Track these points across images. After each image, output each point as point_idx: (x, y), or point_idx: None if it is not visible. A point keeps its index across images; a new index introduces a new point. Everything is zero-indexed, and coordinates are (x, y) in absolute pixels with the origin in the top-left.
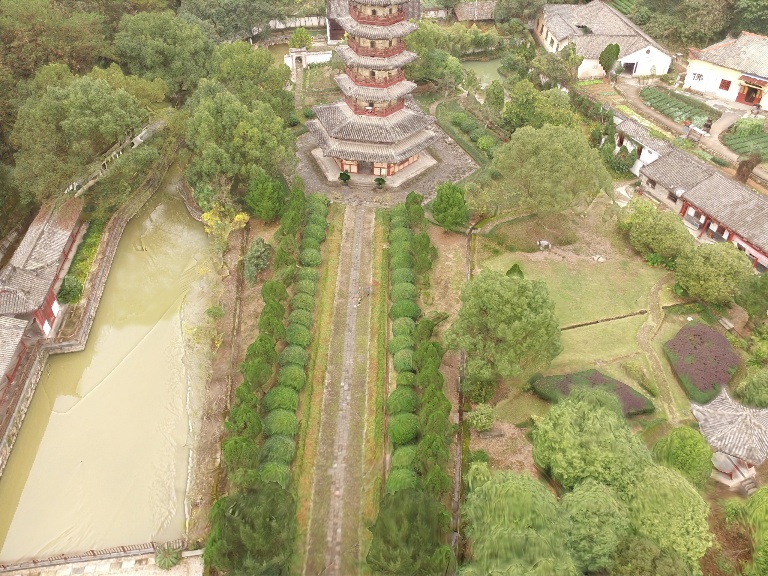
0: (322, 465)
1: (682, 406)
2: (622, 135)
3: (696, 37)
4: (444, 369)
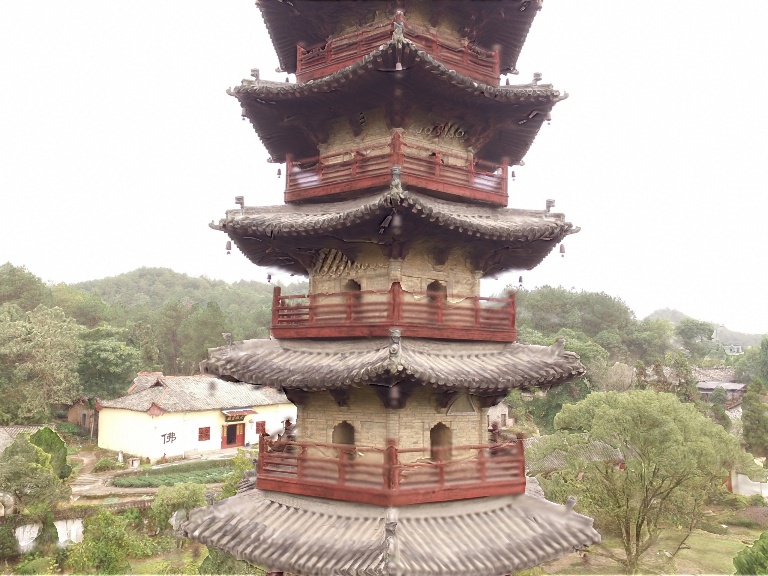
0: None
1: None
2: None
3: (31, 421)
4: None
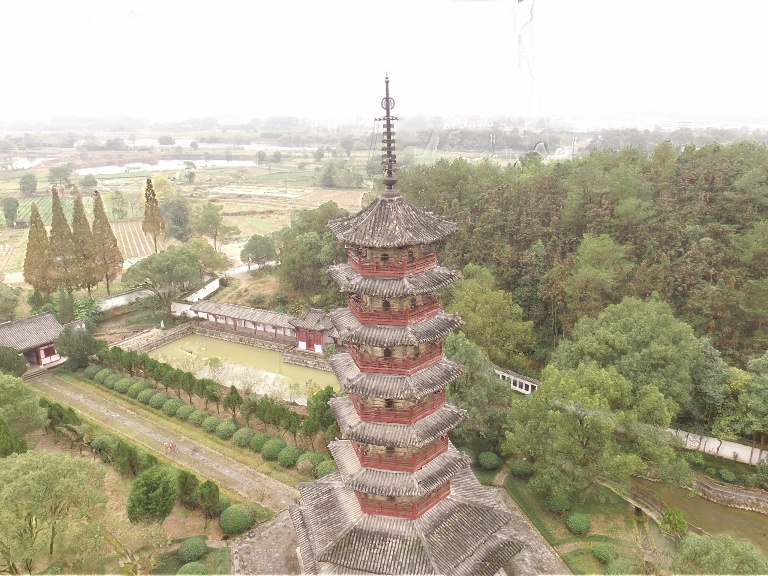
0: (89, 394)
1: None
2: None
3: None
4: None
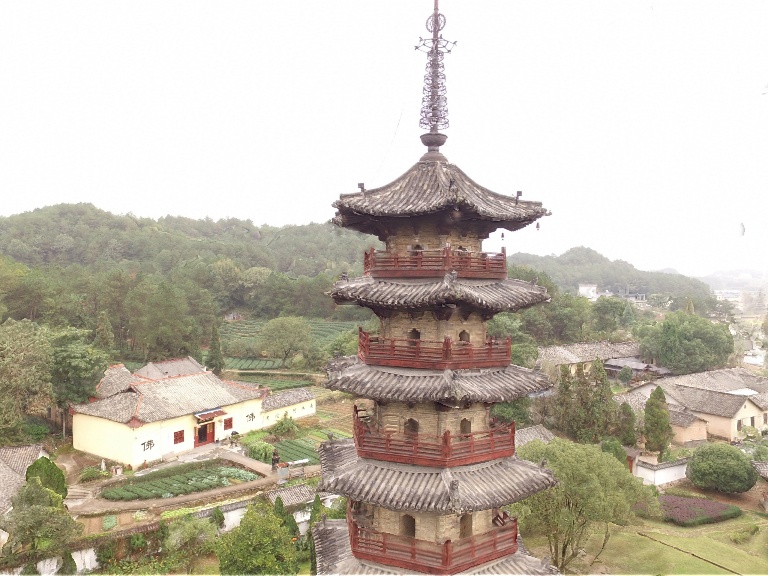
0: None
1: (749, 520)
2: (291, 511)
3: (7, 430)
4: None
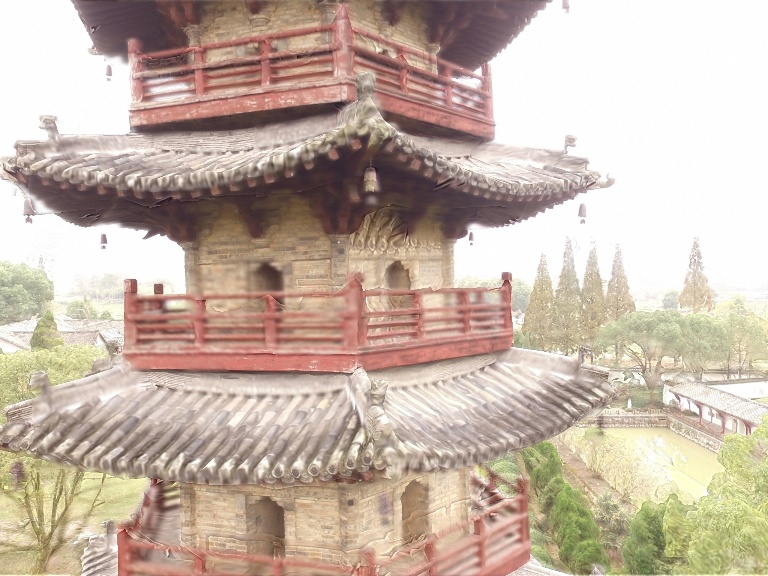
0: None
1: None
2: None
3: None
4: None
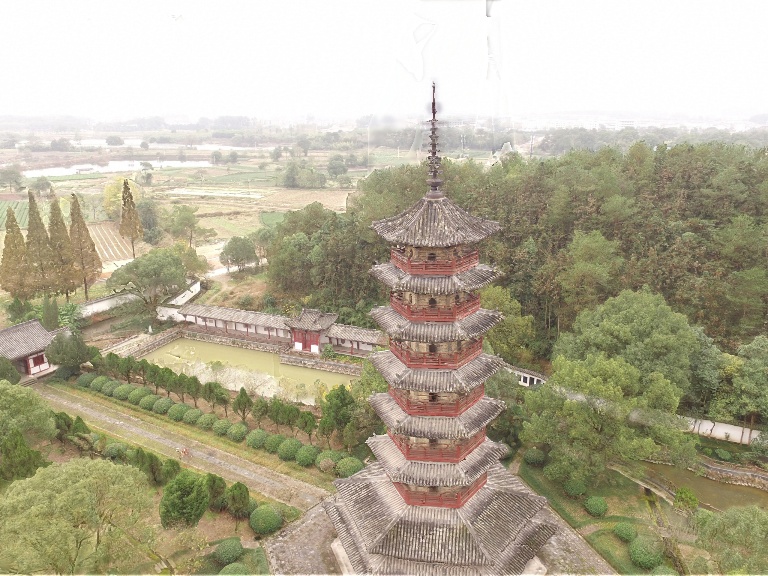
0: (87, 402)
1: None
2: None
3: None
4: (60, 461)
